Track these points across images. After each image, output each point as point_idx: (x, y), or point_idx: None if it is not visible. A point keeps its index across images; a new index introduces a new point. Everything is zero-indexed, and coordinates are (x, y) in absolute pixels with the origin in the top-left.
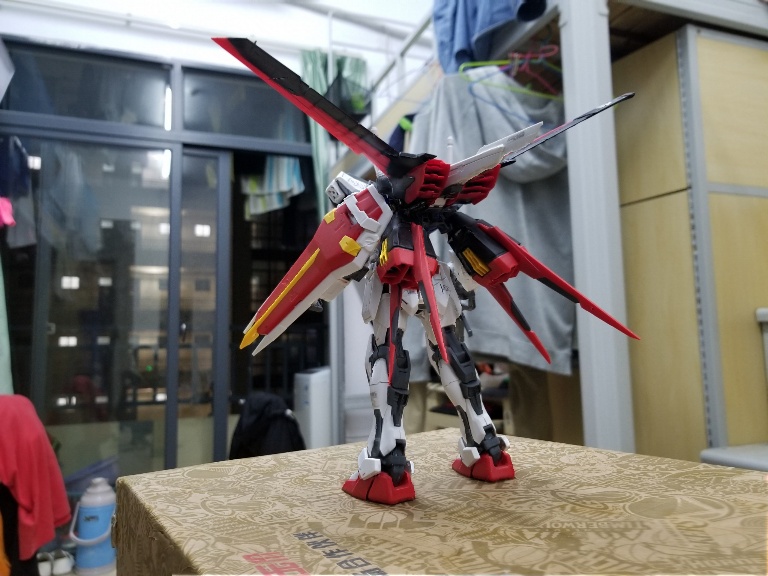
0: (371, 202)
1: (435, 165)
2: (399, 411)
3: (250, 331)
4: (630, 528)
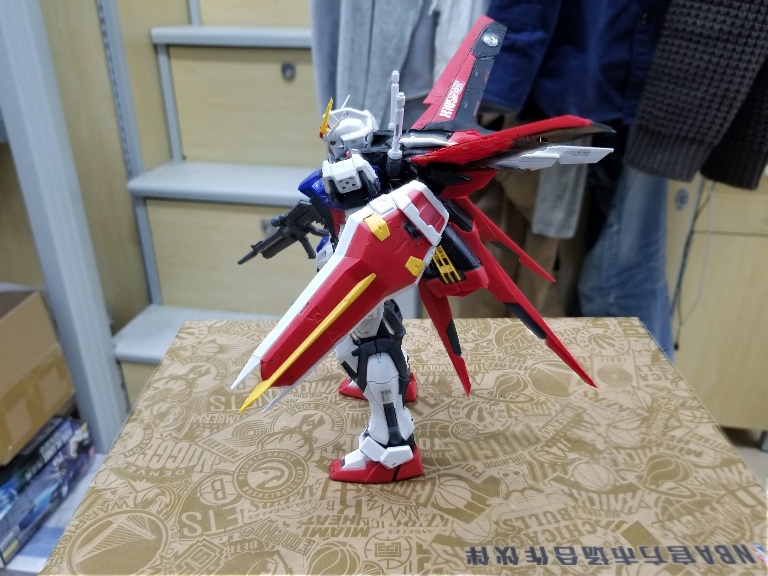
0: (432, 211)
1: None
2: None
3: None
4: (579, 414)
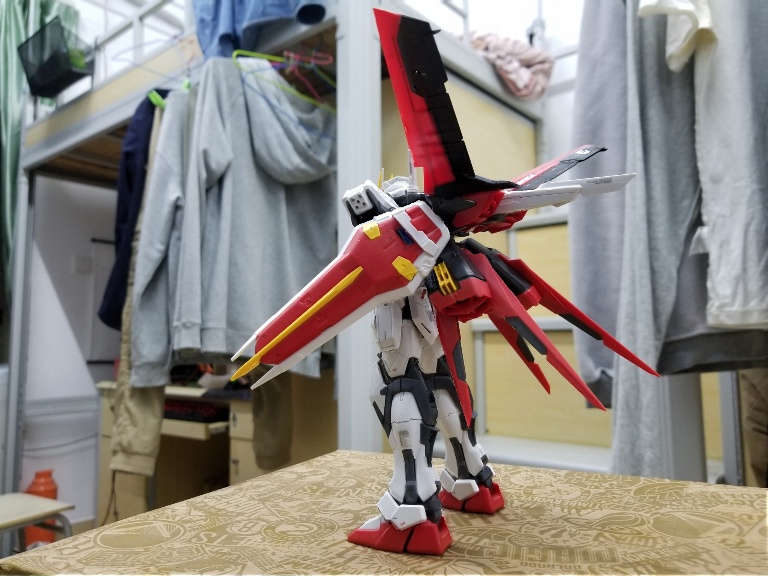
0: (427, 222)
1: None
2: None
3: (252, 359)
4: (696, 552)
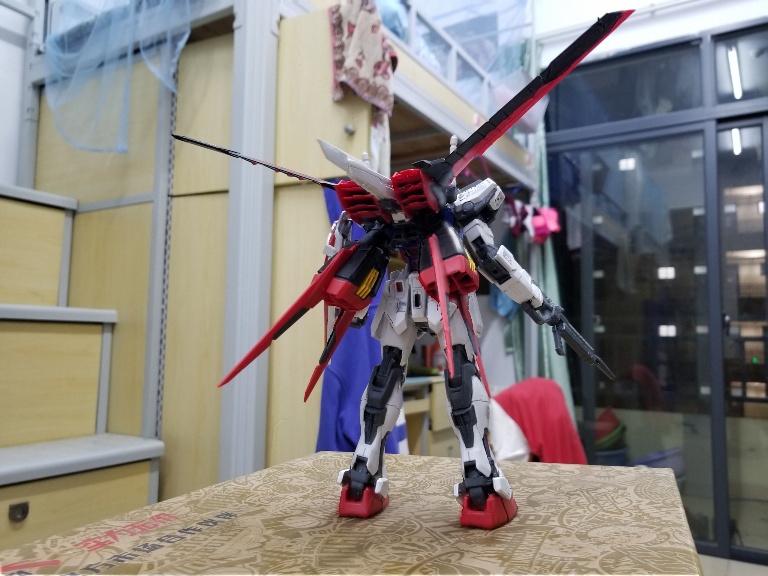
0: None
1: (354, 186)
2: (369, 429)
3: None
4: None
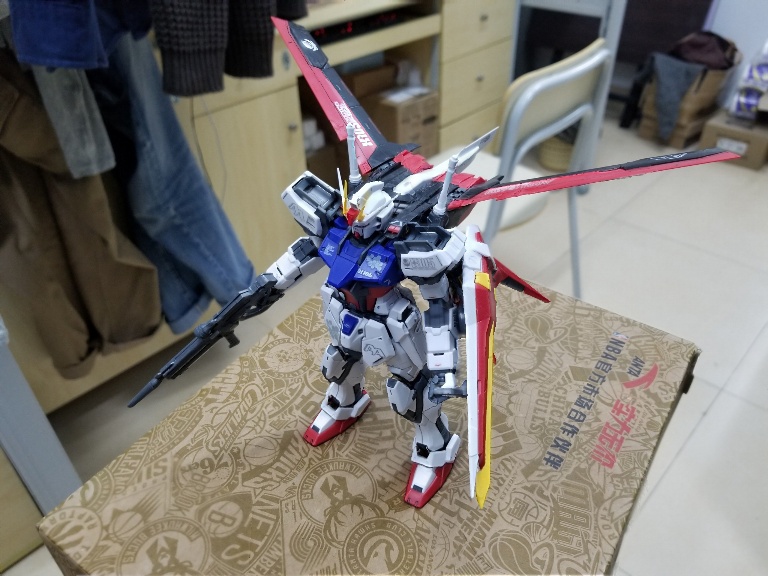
0: None
1: None
2: None
3: None
4: None
